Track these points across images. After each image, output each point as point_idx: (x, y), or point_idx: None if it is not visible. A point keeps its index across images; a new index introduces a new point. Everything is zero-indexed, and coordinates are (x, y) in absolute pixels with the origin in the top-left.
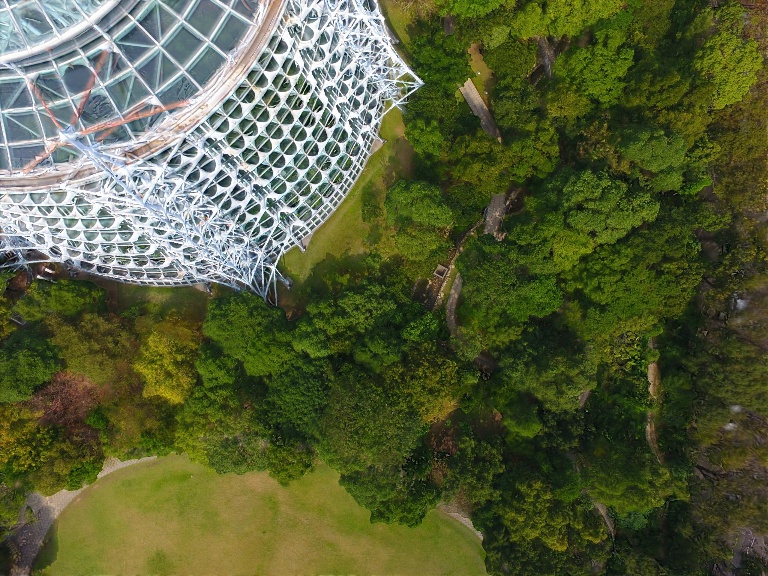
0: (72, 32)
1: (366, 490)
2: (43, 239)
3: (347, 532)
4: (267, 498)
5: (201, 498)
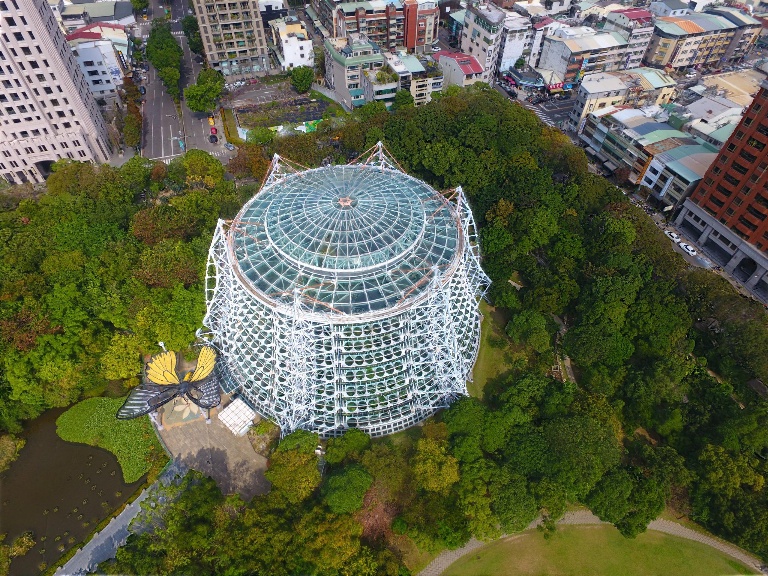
0: (409, 248)
1: (613, 490)
2: (331, 407)
3: None
4: None
5: None
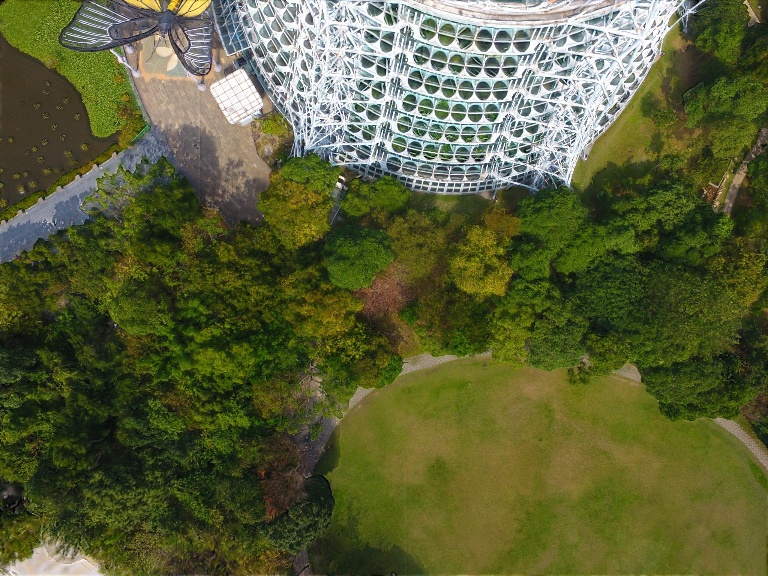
0: None
1: (690, 380)
2: (370, 135)
3: (621, 441)
4: (543, 406)
5: (479, 405)
